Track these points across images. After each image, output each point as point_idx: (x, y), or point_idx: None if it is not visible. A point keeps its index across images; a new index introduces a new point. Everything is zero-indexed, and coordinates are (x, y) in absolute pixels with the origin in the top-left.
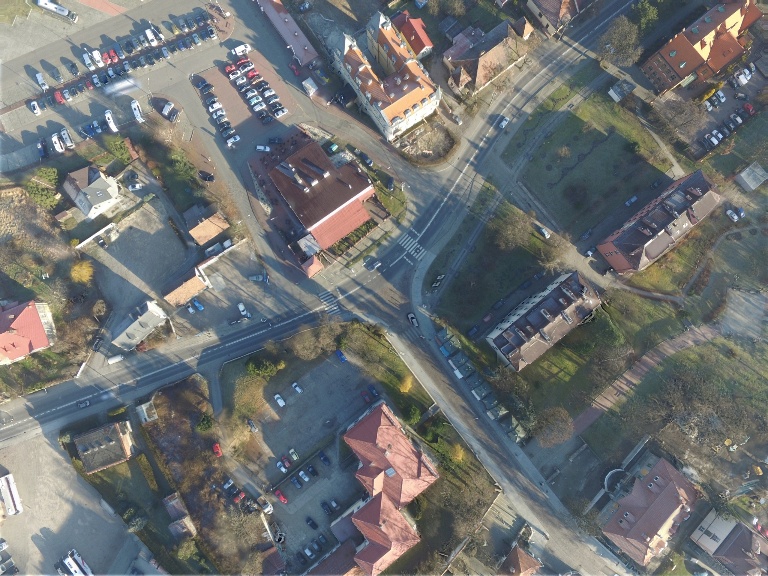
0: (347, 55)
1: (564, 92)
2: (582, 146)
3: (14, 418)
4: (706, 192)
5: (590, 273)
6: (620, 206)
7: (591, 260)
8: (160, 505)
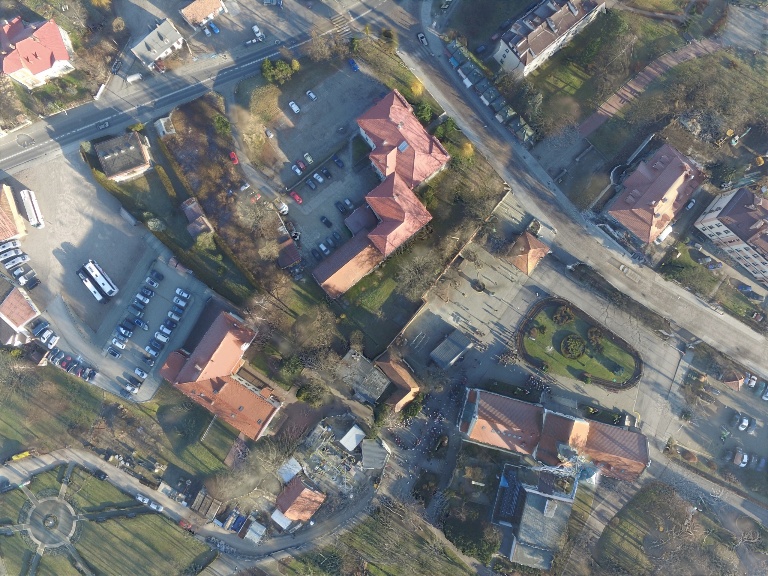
0: None
1: None
2: None
3: (35, 141)
4: None
5: None
6: None
7: None
8: (178, 213)
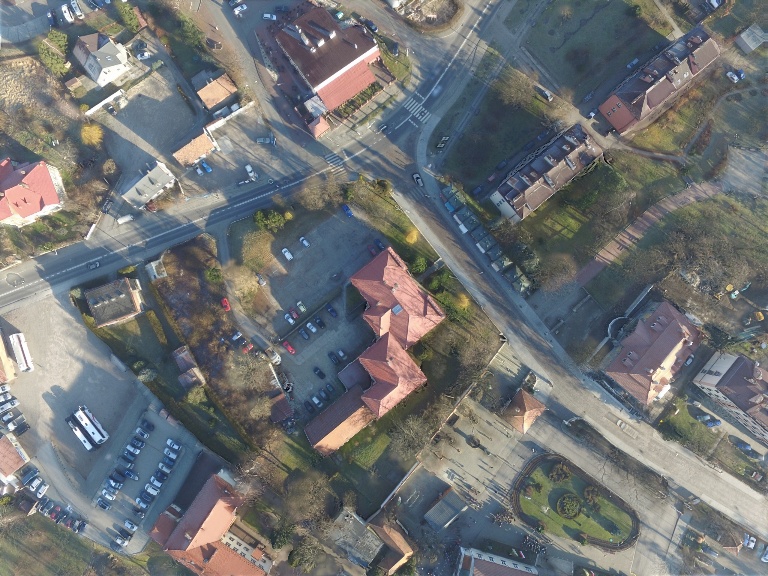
0: None
1: None
2: (584, 11)
3: (25, 280)
4: (706, 39)
5: (592, 133)
6: (622, 68)
7: (593, 122)
8: (169, 360)
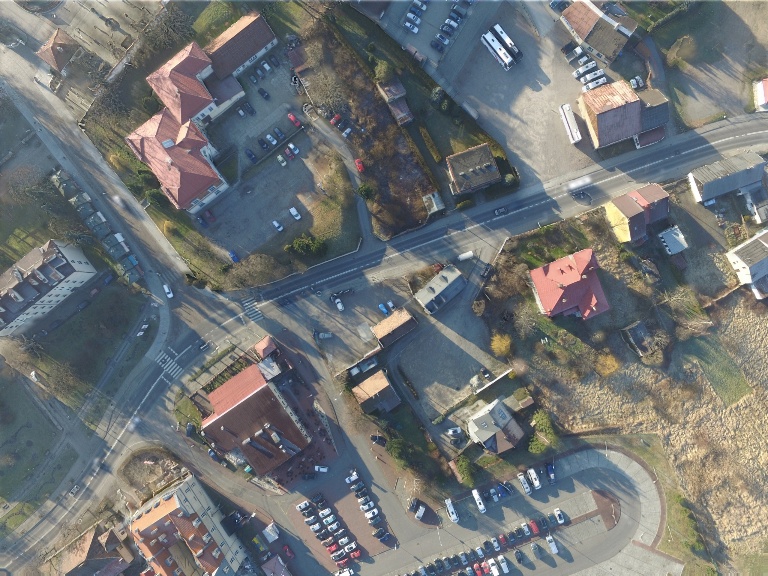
0: (216, 567)
1: (12, 522)
2: None
3: (572, 198)
4: None
5: None
6: None
7: None
8: (419, 112)
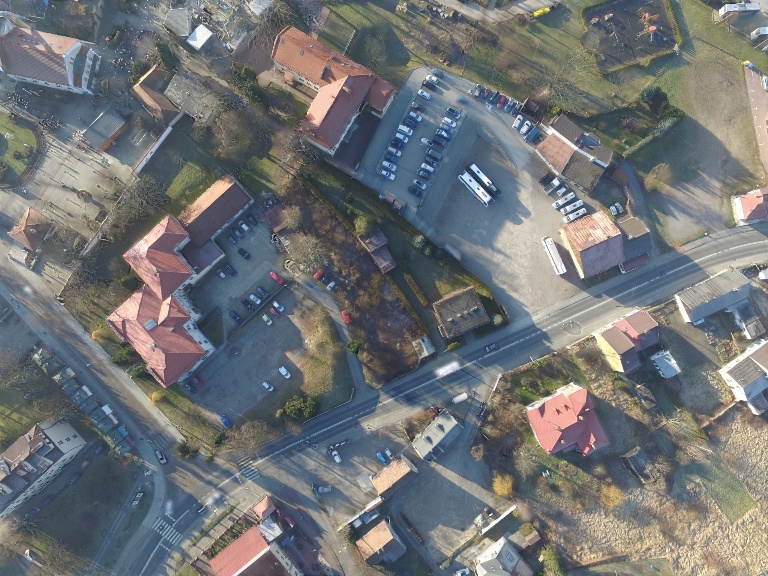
0: None
1: None
2: None
3: (562, 329)
4: None
5: None
6: None
7: None
8: (402, 258)
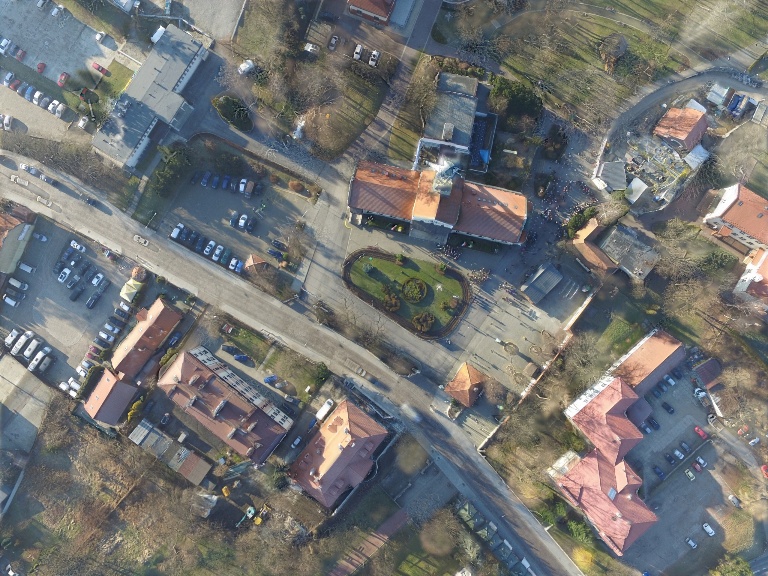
0: None
1: None
2: None
3: None
4: None
5: None
6: None
7: None
8: None
